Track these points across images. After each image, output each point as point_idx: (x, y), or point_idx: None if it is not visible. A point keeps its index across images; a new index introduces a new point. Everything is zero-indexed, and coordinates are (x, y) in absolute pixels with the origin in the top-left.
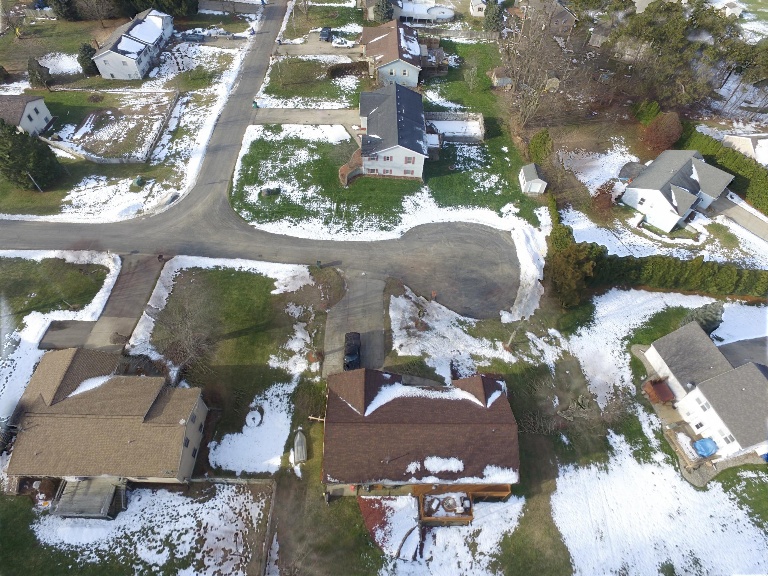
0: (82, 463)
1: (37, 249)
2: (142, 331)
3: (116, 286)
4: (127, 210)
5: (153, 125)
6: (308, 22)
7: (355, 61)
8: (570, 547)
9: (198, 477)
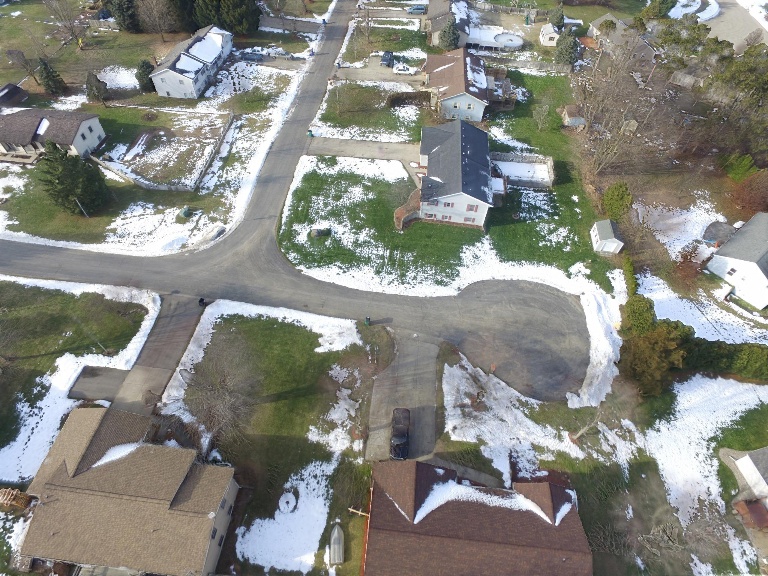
0: (100, 550)
1: (77, 281)
2: (176, 386)
3: (153, 330)
4: (171, 244)
5: (205, 150)
6: (369, 45)
7: (416, 90)
8: None
9: (223, 570)
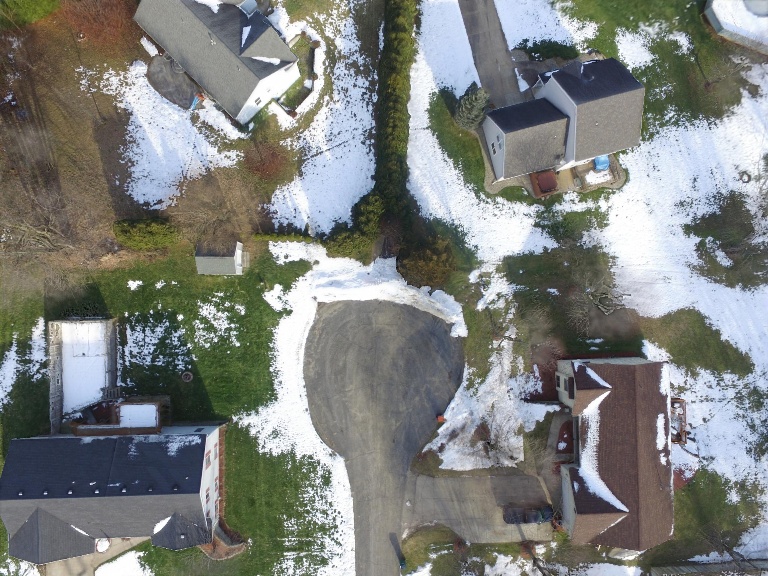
0: None
1: None
2: None
3: None
4: None
5: None
6: None
7: None
8: (678, 308)
9: None
